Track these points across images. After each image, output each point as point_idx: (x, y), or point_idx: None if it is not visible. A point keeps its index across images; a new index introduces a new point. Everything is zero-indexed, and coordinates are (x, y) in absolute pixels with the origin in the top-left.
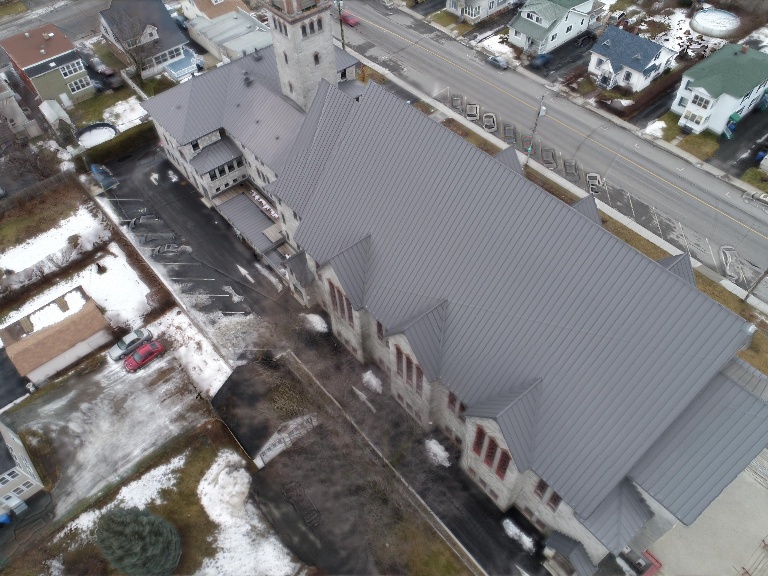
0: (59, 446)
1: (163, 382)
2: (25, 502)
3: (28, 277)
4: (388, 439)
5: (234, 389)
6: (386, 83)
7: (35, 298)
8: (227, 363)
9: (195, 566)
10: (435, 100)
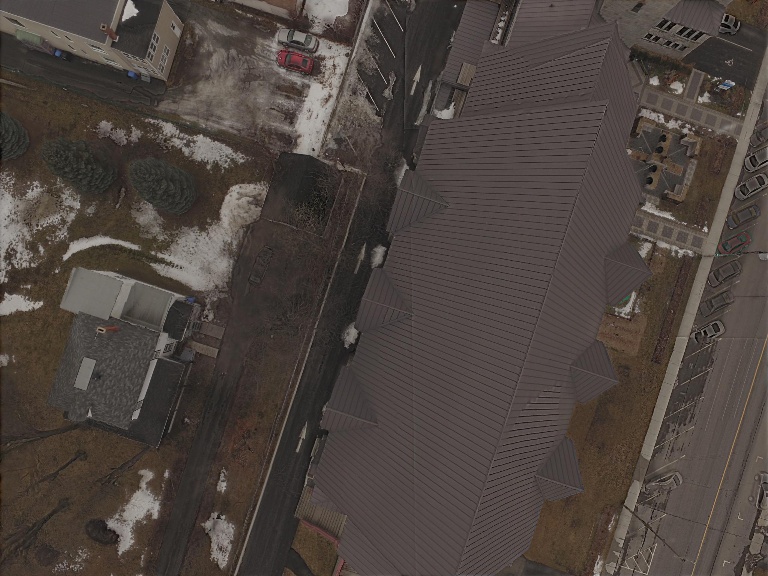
0: (197, 63)
1: (286, 95)
2: (151, 78)
3: None
4: (340, 295)
5: (294, 166)
6: (763, 32)
7: None
8: (325, 134)
9: (189, 224)
10: (760, 106)
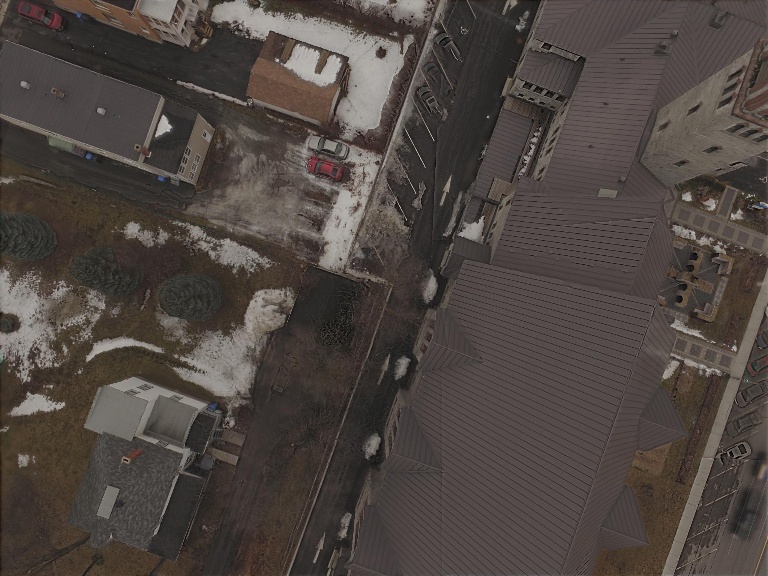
0: (226, 167)
1: (314, 202)
2: (180, 181)
3: (330, 0)
4: (363, 406)
5: (322, 283)
6: None
7: (323, 20)
8: (353, 244)
9: (213, 328)
10: None
